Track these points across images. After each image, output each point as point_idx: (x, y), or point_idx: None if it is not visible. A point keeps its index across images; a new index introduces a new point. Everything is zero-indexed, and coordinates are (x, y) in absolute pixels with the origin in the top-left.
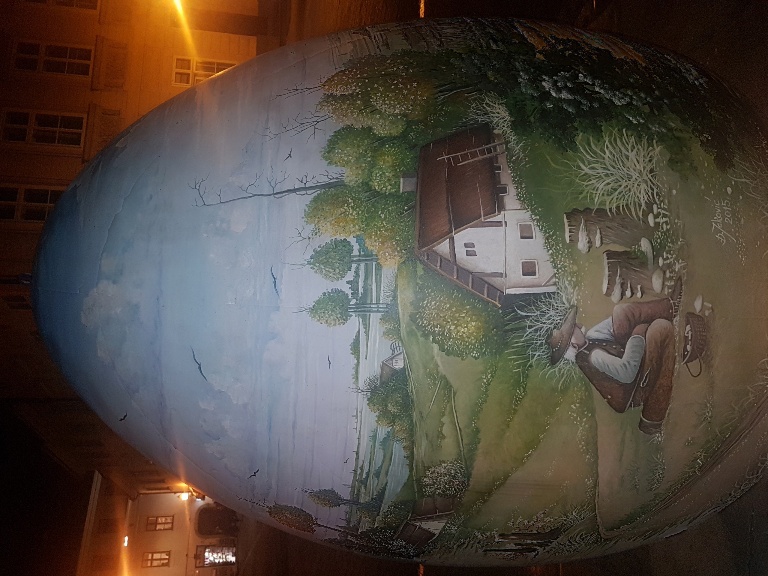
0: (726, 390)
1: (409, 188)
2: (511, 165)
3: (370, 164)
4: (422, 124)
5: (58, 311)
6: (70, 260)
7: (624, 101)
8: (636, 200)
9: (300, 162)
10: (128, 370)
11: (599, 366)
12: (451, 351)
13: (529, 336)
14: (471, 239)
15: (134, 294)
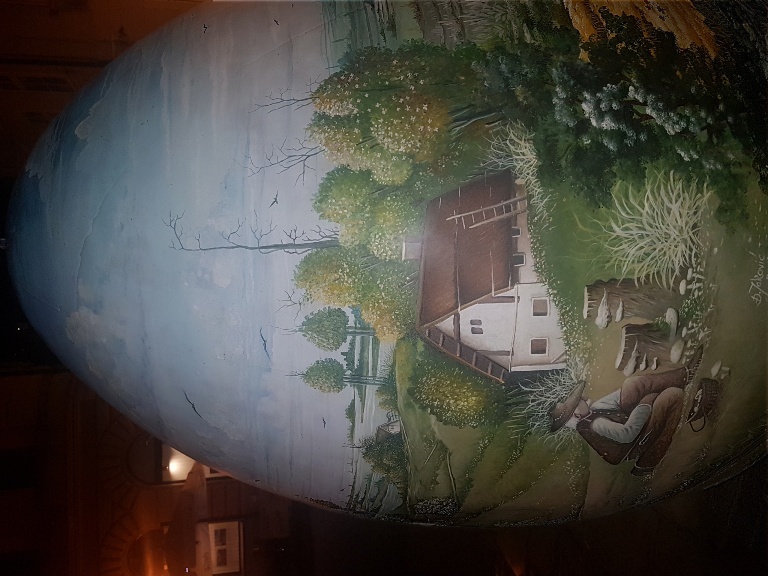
0: (726, 436)
1: (412, 255)
2: (532, 228)
3: (368, 222)
4: (431, 170)
5: (42, 315)
6: (45, 270)
7: (679, 127)
8: (670, 265)
9: (288, 211)
10: (122, 391)
11: (600, 431)
12: (449, 421)
13: (531, 409)
14: (478, 316)
15: (118, 330)
